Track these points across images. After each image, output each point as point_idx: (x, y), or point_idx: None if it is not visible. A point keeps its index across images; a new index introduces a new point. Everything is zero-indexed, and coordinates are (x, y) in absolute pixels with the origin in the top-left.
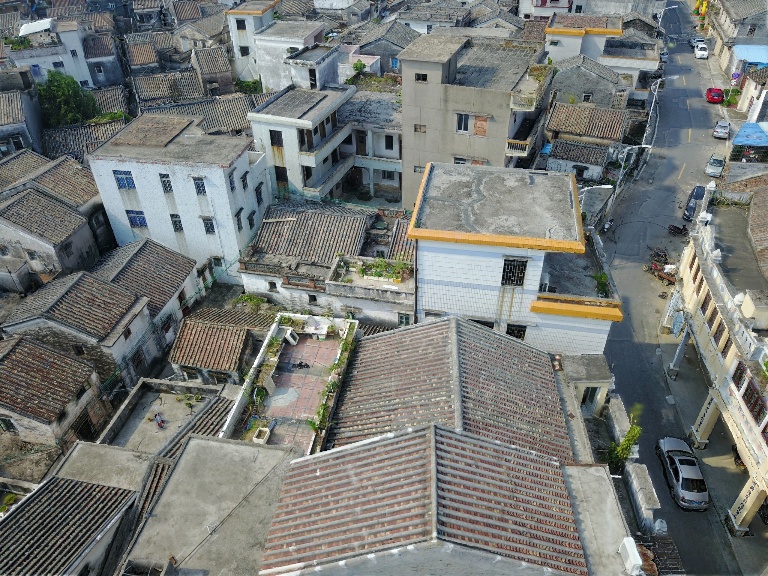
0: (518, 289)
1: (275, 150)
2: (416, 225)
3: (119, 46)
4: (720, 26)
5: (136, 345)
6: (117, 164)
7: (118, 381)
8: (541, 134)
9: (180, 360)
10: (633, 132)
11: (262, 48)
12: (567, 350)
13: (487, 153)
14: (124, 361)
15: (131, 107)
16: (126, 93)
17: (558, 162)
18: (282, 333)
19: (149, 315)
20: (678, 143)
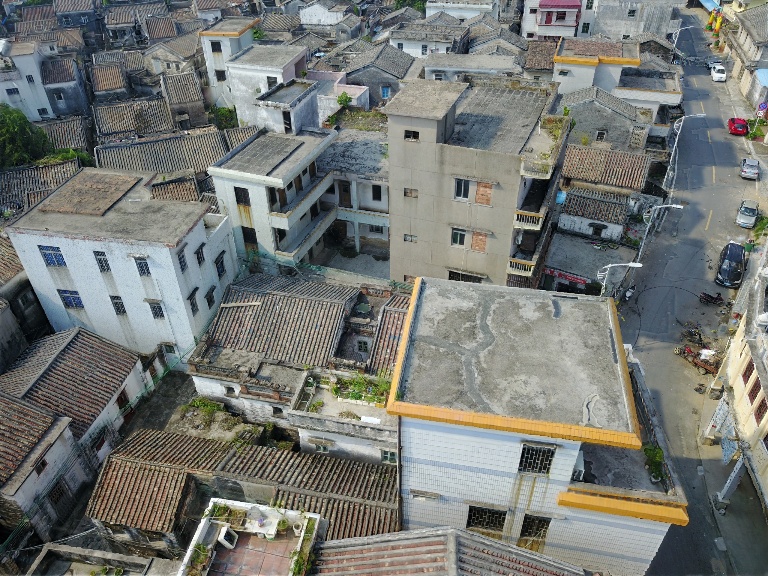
0: (541, 478)
1: (241, 209)
2: (399, 392)
3: (82, 69)
4: (740, 47)
5: (55, 477)
6: (42, 239)
7: (27, 530)
8: (554, 194)
9: (100, 515)
10: (651, 171)
11: (236, 77)
12: (606, 546)
13: (491, 224)
14: (37, 501)
15: (92, 139)
16: (89, 122)
17: (572, 219)
18: (214, 532)
19: (72, 437)
20: (702, 184)
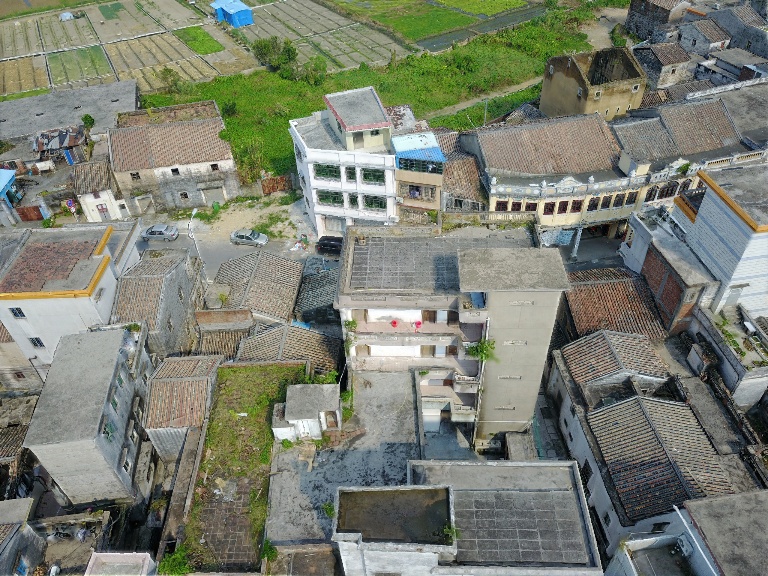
0: None
1: None
2: None
3: None
4: None
5: None
6: None
7: None
8: None
9: None
10: None
11: None
12: None
13: None
14: None
15: None
16: None
17: None
18: None
19: None
20: None
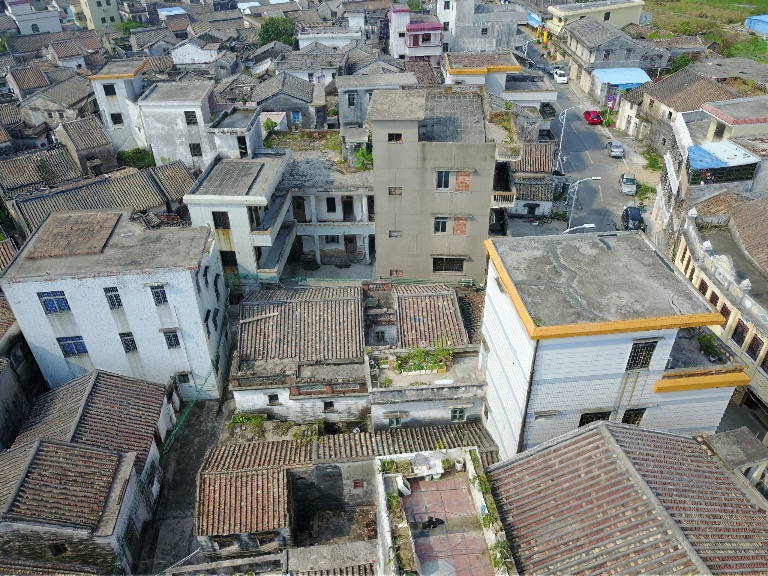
0: (643, 372)
1: (220, 233)
2: None
3: None
4: (575, 53)
5: (127, 517)
6: (43, 285)
7: None
8: None
9: (210, 530)
10: None
11: (150, 115)
12: (685, 423)
13: (471, 208)
14: (118, 544)
15: None
16: None
17: None
18: (391, 484)
19: (135, 473)
20: (584, 166)
